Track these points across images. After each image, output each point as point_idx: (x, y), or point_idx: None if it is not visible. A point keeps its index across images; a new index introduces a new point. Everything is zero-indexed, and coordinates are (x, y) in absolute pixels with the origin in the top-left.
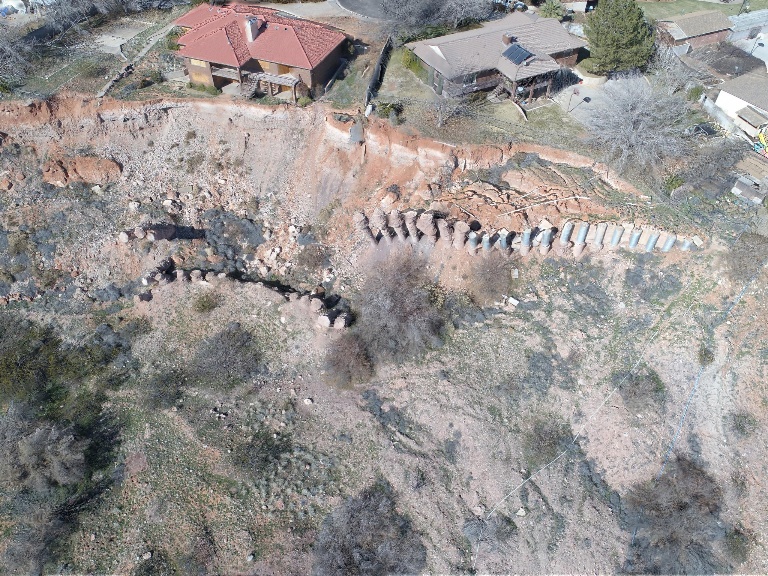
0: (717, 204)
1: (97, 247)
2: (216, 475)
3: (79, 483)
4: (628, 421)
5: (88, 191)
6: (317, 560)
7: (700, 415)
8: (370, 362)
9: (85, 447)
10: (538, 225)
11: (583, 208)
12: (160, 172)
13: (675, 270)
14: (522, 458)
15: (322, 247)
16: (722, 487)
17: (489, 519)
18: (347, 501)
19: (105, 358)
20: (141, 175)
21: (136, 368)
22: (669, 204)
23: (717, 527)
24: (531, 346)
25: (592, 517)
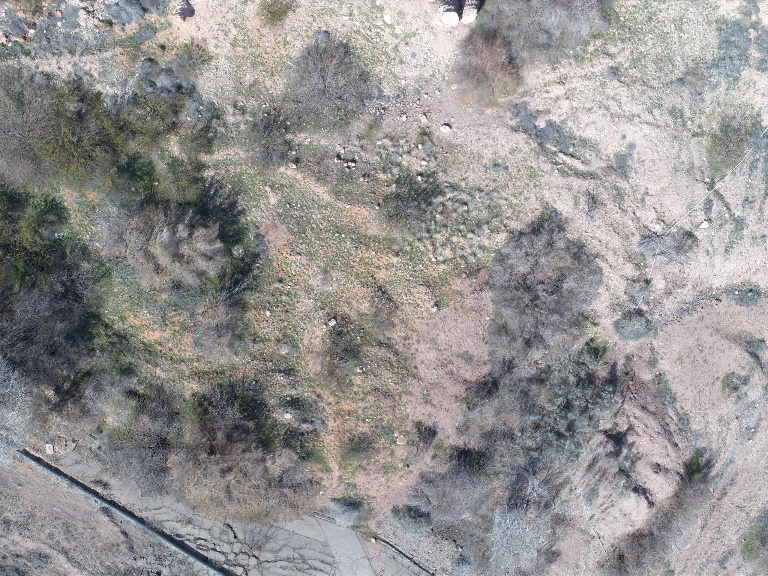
0: None
1: None
2: (372, 235)
3: (224, 264)
4: None
5: None
6: (496, 296)
7: None
8: (514, 65)
9: (217, 232)
10: None
11: None
12: None
13: None
14: (706, 165)
15: None
16: None
17: (668, 235)
18: (514, 235)
19: (172, 109)
20: None
21: (217, 116)
22: None
23: None
24: (725, 13)
25: None
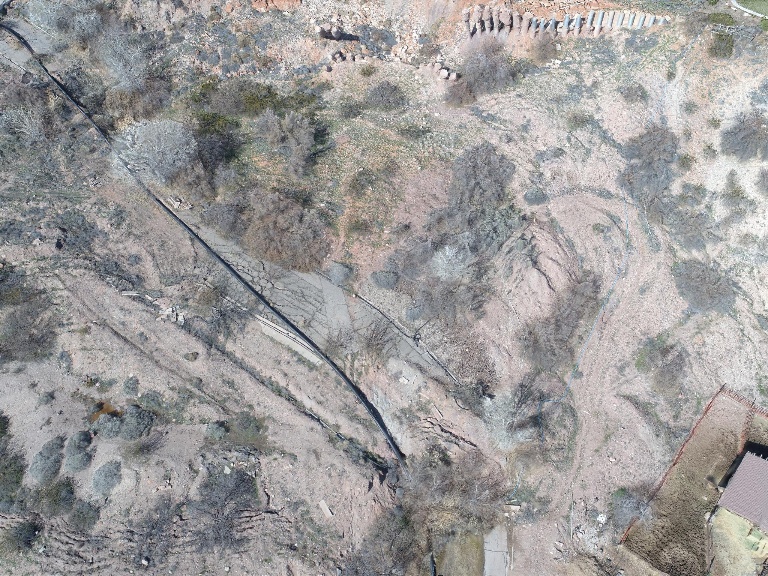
0: (680, 1)
1: (293, 43)
2: (392, 140)
3: (311, 148)
4: (626, 107)
5: (281, 14)
6: (455, 172)
7: (667, 106)
8: (473, 95)
9: (314, 128)
10: (573, 17)
11: (600, 5)
12: (327, 3)
13: (654, 35)
14: (566, 127)
15: (434, 45)
16: (678, 138)
17: (549, 150)
18: (467, 151)
19: (308, 100)
20: (314, 5)
21: None
22: (652, 1)
23: (675, 155)
24: (569, 82)
25: (606, 150)
